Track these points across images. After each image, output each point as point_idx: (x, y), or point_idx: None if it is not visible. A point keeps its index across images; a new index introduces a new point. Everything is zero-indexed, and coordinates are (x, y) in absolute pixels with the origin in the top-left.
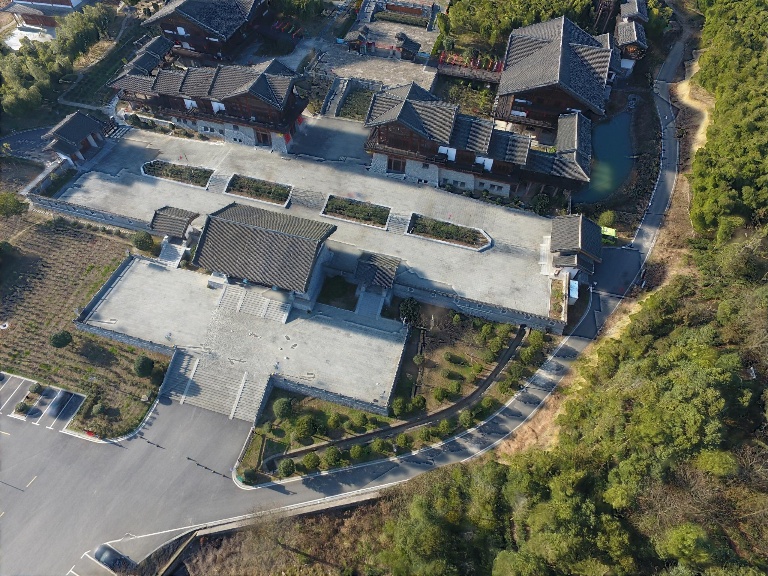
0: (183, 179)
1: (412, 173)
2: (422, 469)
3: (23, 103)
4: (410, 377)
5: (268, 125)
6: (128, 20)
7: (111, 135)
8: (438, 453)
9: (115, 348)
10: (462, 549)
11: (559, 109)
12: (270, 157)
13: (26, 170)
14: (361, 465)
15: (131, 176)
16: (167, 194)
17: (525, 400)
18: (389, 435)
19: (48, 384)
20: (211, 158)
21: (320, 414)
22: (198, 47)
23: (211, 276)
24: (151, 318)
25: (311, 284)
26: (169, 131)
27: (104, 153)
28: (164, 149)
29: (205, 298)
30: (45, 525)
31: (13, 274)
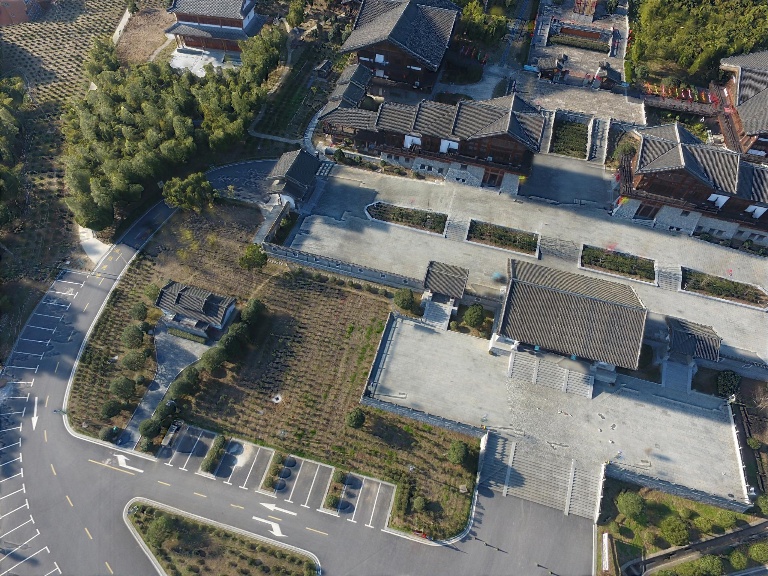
0: (415, 224)
1: (665, 220)
2: None
3: (228, 138)
4: (767, 468)
5: (511, 167)
6: (293, 42)
7: None
8: None
9: (410, 427)
10: None
11: None
12: (500, 199)
13: (242, 213)
14: (736, 574)
15: (357, 220)
16: (404, 242)
17: None
18: (754, 537)
19: (348, 471)
20: (438, 200)
21: (665, 509)
22: (393, 75)
23: (494, 341)
24: (443, 392)
25: None
26: (377, 168)
27: (318, 193)
28: (380, 189)
29: (492, 367)
30: None
31: (271, 337)
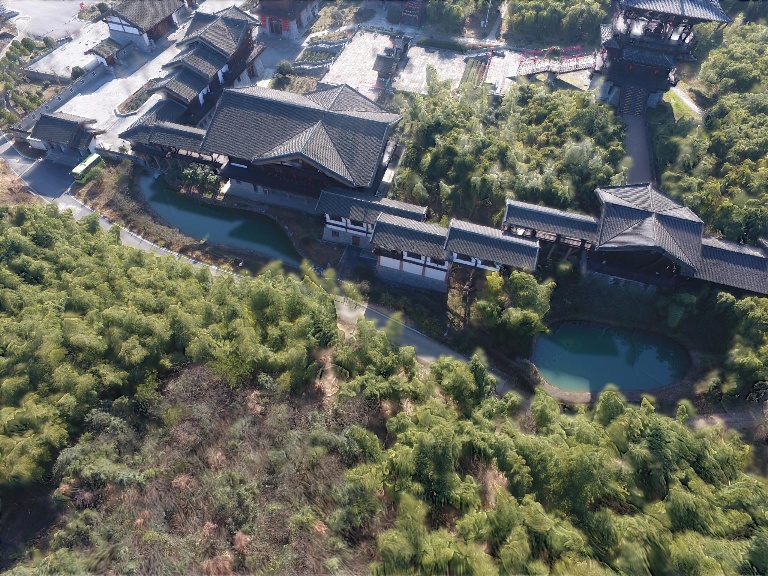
0: None
1: None
2: None
3: None
4: (28, 71)
5: (256, 2)
6: None
7: None
8: None
9: None
10: None
11: None
12: None
13: None
14: (5, 70)
15: None
16: (233, 3)
17: None
18: None
19: None
20: None
21: None
22: None
23: None
24: None
25: (117, 38)
26: None
27: None
28: None
29: None
30: (51, 8)
31: None
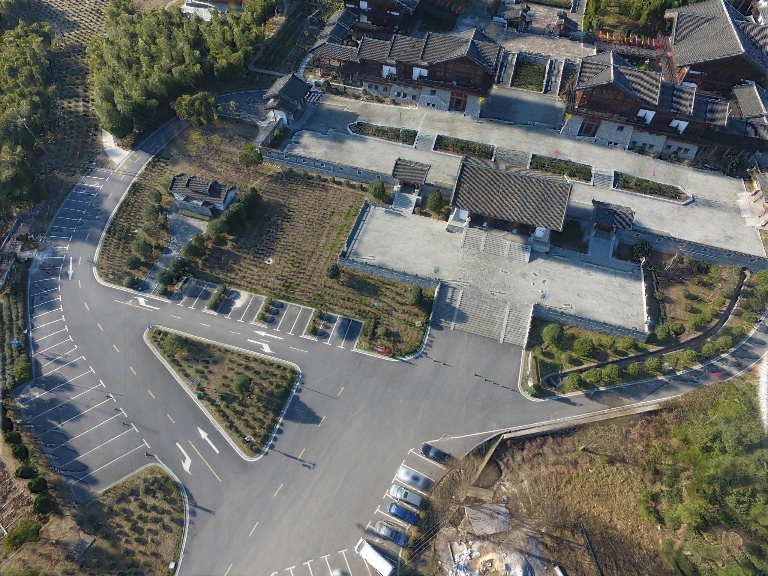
0: (390, 138)
1: (604, 136)
2: (691, 386)
3: (231, 67)
4: (664, 307)
5: (472, 89)
6: None
7: (307, 99)
8: (701, 374)
9: (377, 281)
10: (764, 447)
11: (734, 80)
12: (464, 120)
13: (241, 128)
14: (633, 383)
15: (341, 135)
16: (380, 151)
17: (765, 331)
18: None
19: (325, 311)
20: (410, 120)
21: None
22: (375, 21)
23: (450, 221)
24: (405, 256)
25: None
26: (359, 97)
27: (308, 115)
28: (361, 112)
29: (448, 240)
30: (366, 427)
31: (265, 217)
